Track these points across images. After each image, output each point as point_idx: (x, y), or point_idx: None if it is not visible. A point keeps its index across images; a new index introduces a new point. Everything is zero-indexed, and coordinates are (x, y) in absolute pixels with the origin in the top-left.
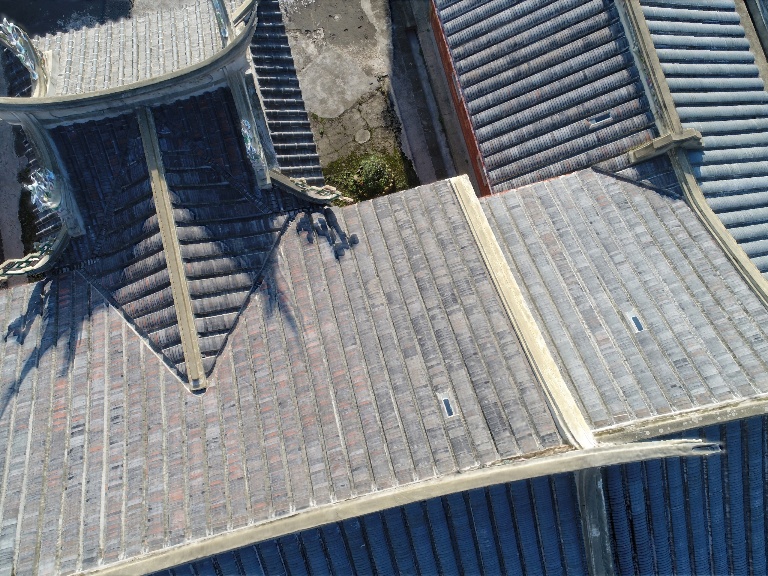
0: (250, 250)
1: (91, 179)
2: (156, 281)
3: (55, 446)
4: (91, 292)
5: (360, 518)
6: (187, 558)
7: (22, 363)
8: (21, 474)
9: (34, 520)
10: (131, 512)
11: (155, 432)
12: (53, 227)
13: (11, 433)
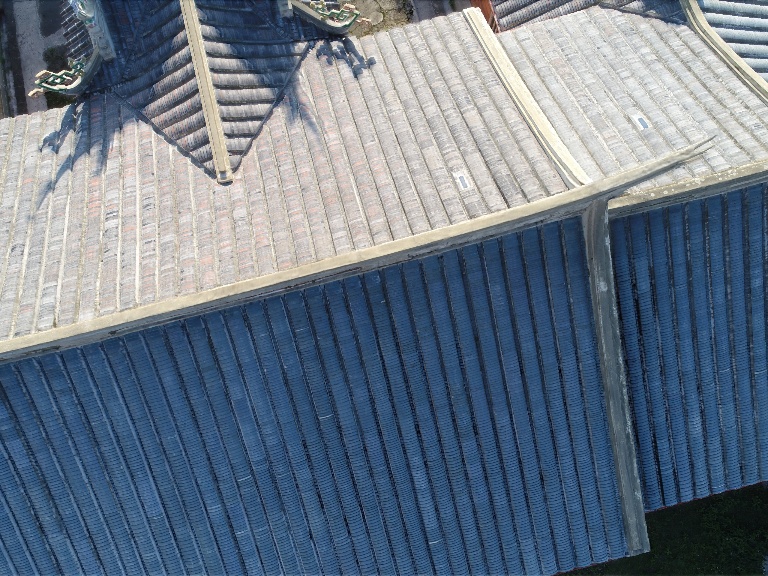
0: (272, 70)
1: (121, 4)
2: (184, 91)
3: (91, 228)
4: (121, 110)
5: (381, 274)
6: (219, 295)
7: (57, 167)
8: (60, 249)
9: (73, 282)
10: (164, 274)
11: (185, 215)
12: (84, 55)
13: (49, 220)
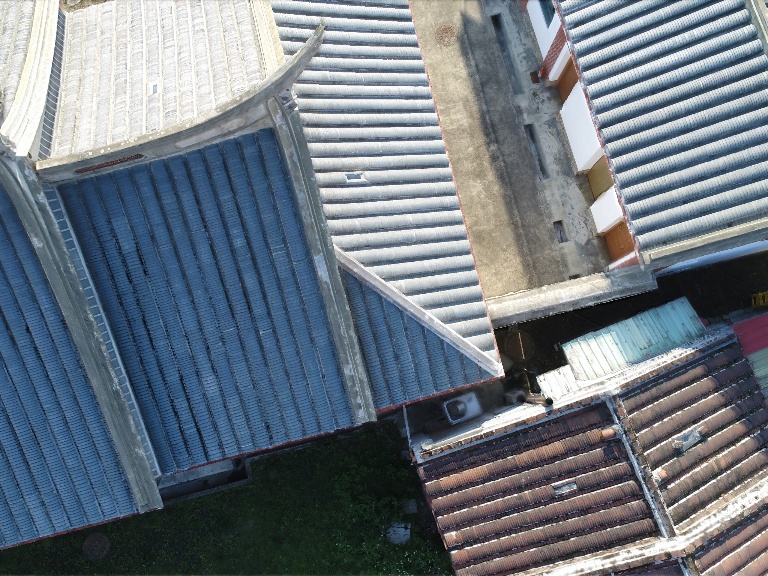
0: None
1: None
2: None
3: None
4: None
5: None
6: None
7: None
8: None
9: None
10: None
11: None
12: None
13: None
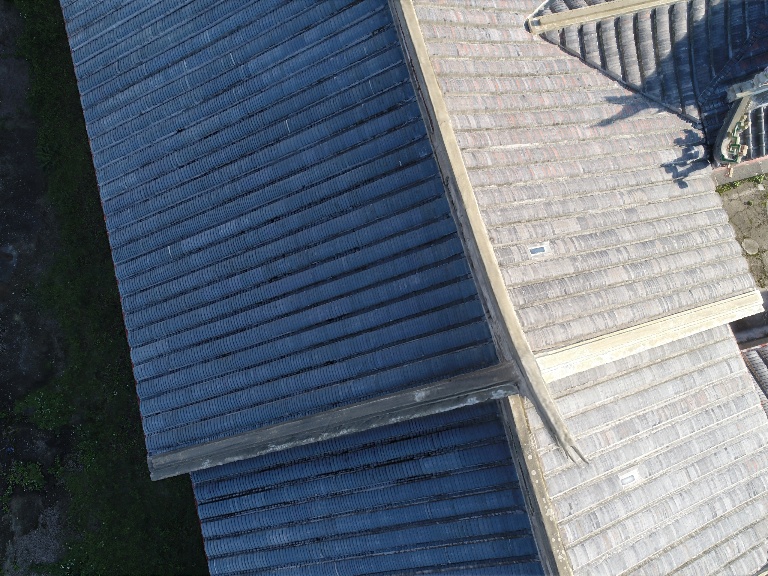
0: (662, 81)
1: None
2: None
3: None
4: None
5: (429, 157)
6: None
7: None
8: None
9: None
10: None
11: None
12: None
13: None
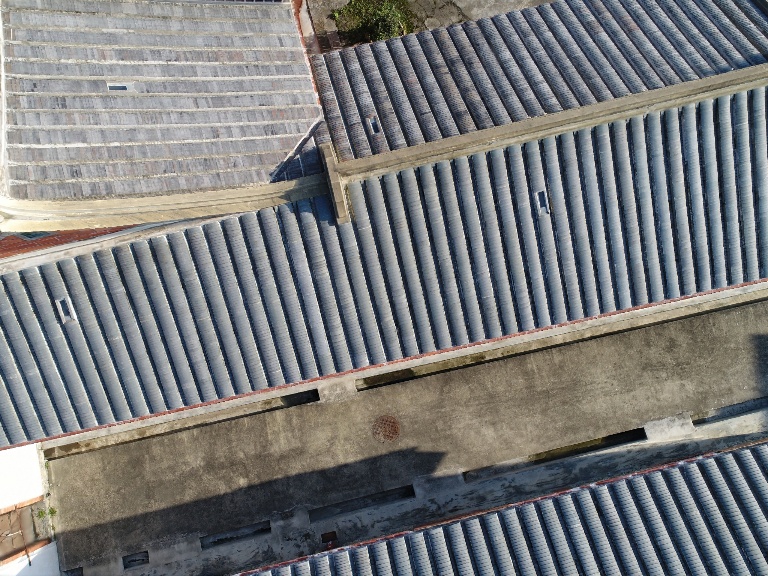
0: None
1: None
2: None
3: None
4: None
5: None
6: None
7: None
8: None
9: None
10: None
11: None
12: None
13: None
